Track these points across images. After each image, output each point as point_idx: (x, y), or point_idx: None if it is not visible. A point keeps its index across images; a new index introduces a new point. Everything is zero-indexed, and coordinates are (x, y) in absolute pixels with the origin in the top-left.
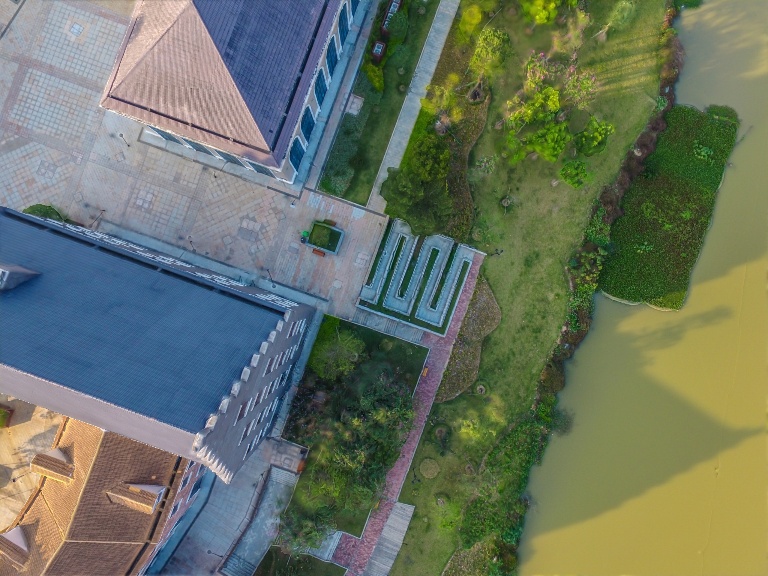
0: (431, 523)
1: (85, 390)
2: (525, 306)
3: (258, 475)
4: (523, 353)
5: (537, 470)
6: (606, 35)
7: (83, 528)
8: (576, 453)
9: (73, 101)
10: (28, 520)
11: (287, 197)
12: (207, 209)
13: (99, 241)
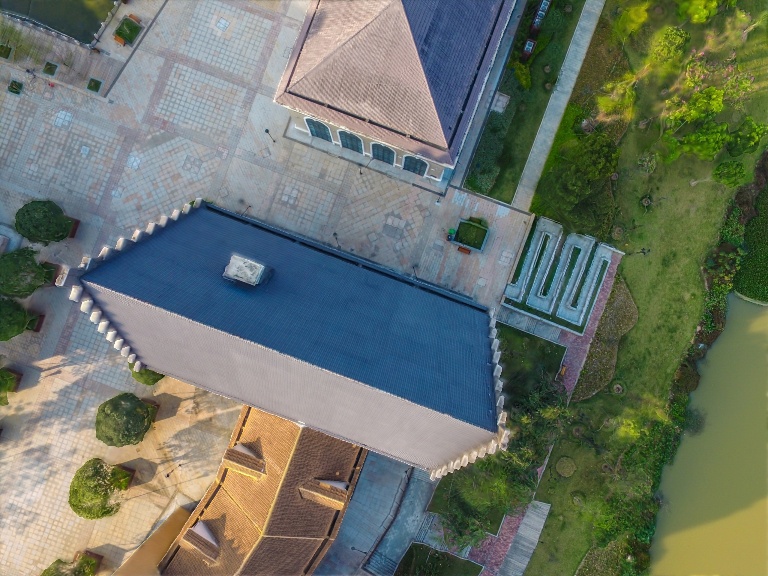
0: (566, 521)
1: (377, 385)
2: (662, 306)
3: (402, 472)
4: (659, 353)
5: (669, 469)
6: (747, 35)
7: (278, 523)
8: (707, 453)
9: (219, 96)
10: (211, 515)
11: (432, 194)
12: (352, 206)
13: None
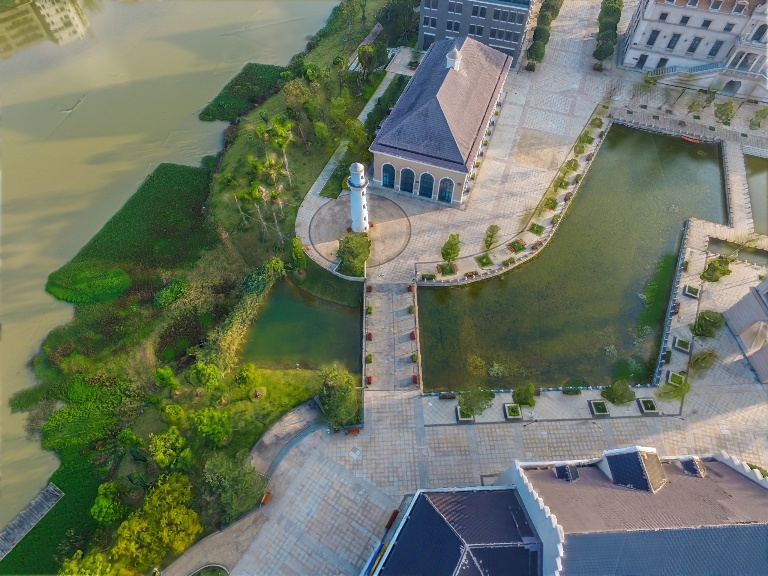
0: None
1: None
2: None
3: None
4: None
5: None
6: None
7: None
8: None
9: None
10: None
11: None
12: None
13: (494, 3)
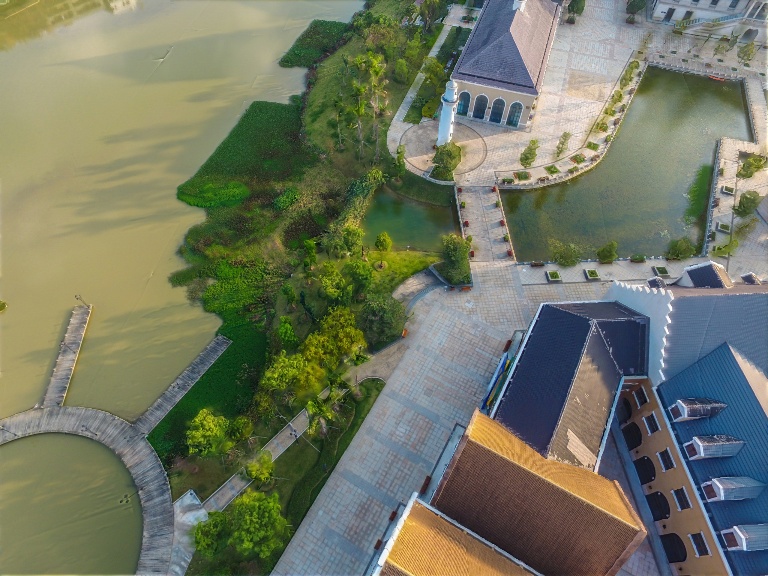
0: None
1: None
2: None
3: None
4: (382, 8)
5: None
6: None
7: None
8: None
9: None
10: None
11: None
12: None
13: None
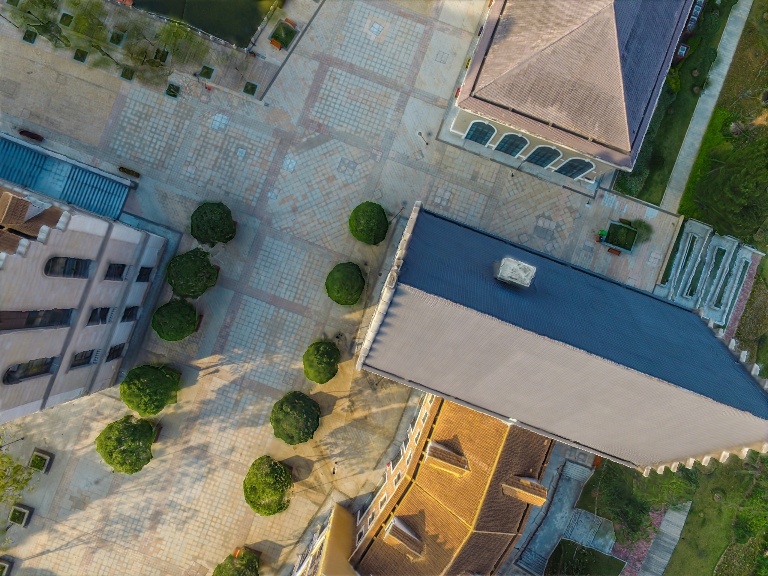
0: (706, 518)
1: (677, 384)
2: None
3: (553, 469)
4: None
5: None
6: None
7: (485, 519)
8: None
9: (373, 99)
10: (407, 511)
11: (582, 196)
12: (504, 207)
13: None
